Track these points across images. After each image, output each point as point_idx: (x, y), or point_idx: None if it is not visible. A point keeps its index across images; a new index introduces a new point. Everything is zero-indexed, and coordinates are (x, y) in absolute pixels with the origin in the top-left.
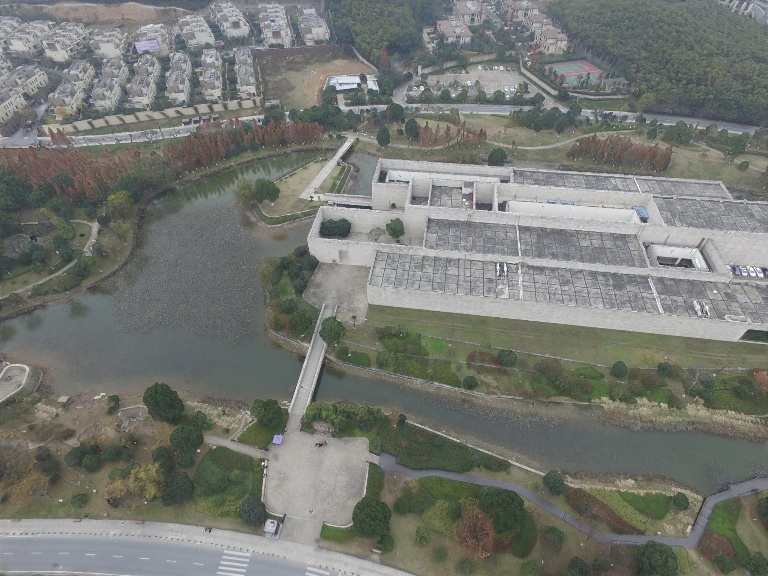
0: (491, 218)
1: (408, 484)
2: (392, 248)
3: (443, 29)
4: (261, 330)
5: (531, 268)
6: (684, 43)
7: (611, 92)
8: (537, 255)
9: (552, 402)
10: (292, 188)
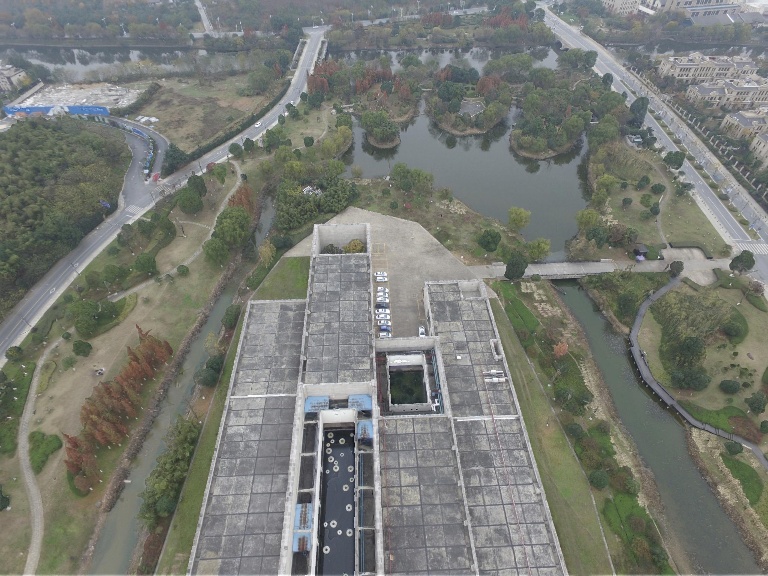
0: None
1: None
2: None
3: None
4: None
5: None
6: None
7: None
8: None
9: (679, 572)
10: None
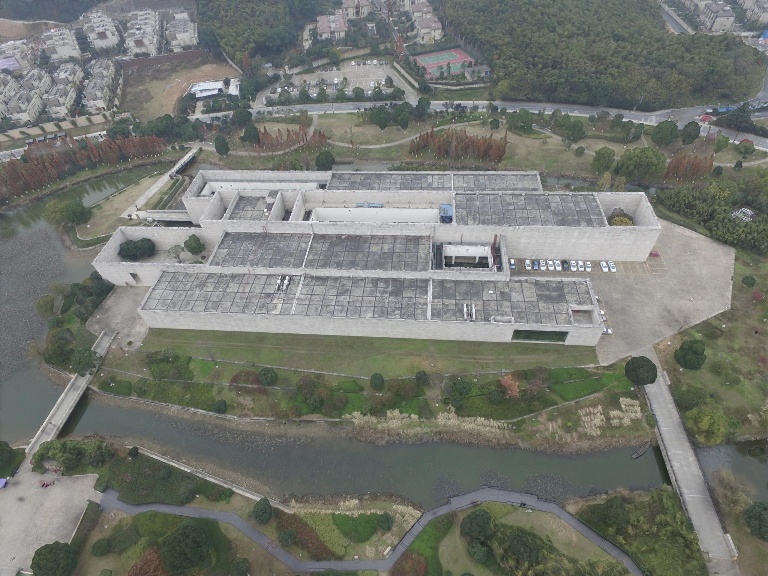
0: (286, 228)
1: (122, 522)
2: (176, 267)
3: (318, 25)
4: (35, 363)
5: (314, 279)
6: (546, 25)
7: (472, 81)
8: (321, 265)
9: (303, 421)
10: (116, 207)
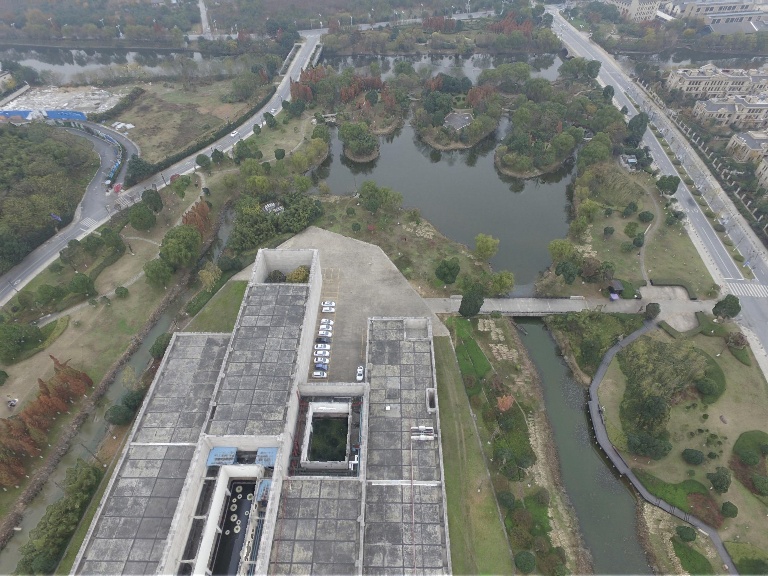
0: None
1: None
2: None
3: None
4: None
5: None
6: None
7: None
8: None
9: None
10: None
